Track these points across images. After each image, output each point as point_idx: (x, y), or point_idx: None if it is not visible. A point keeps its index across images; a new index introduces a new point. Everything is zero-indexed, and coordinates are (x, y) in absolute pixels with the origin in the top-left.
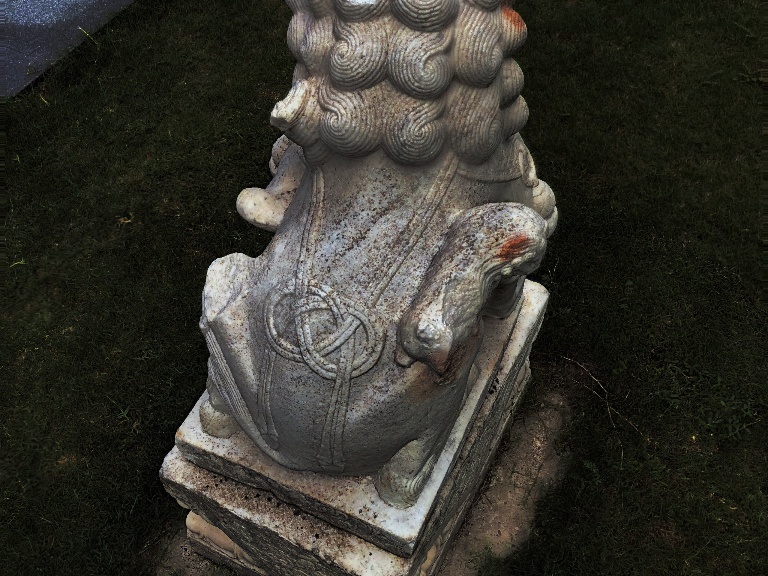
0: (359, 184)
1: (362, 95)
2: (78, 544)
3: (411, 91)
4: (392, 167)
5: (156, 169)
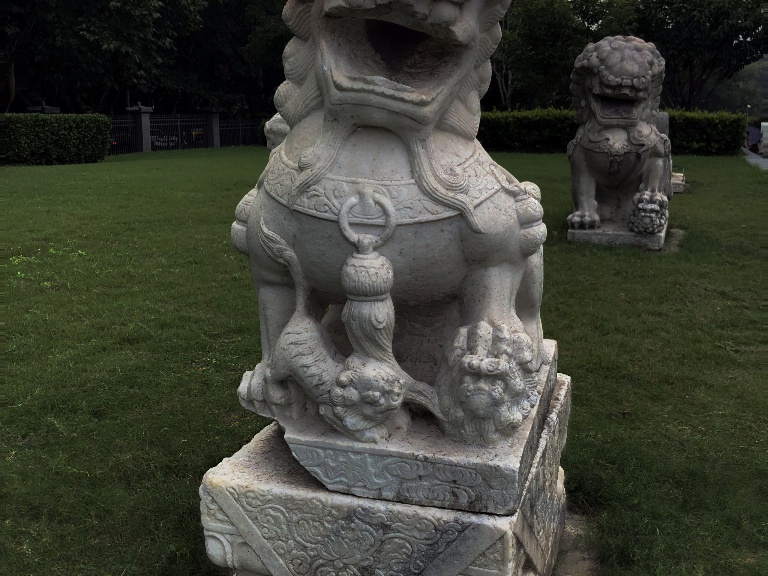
0: None
1: None
2: None
3: None
4: None
5: None
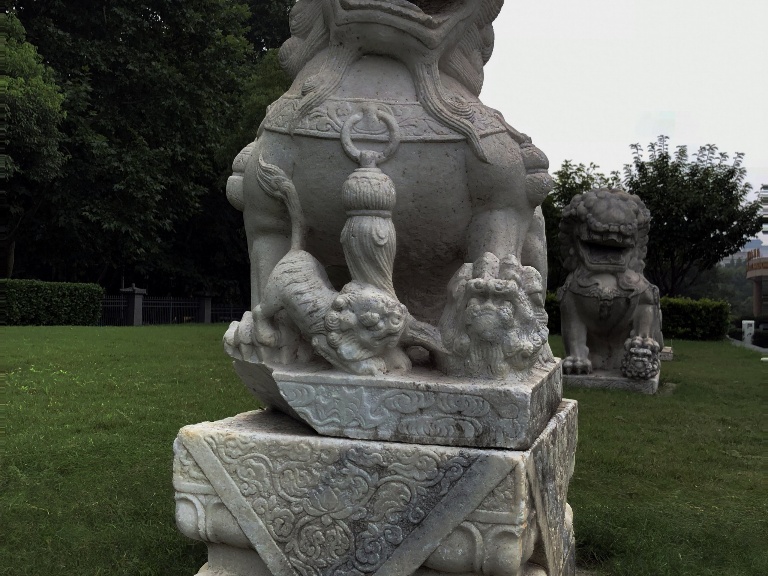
0: None
1: None
2: (688, 569)
3: None
4: None
5: None
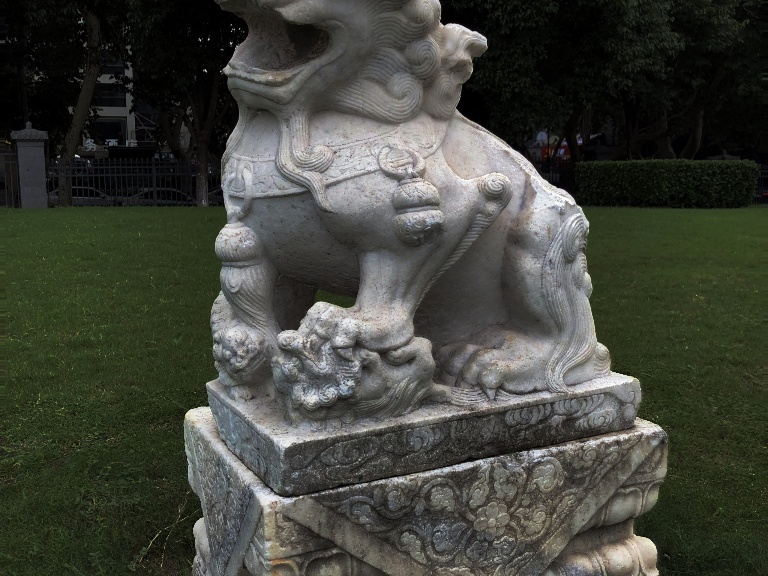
0: None
1: None
2: None
3: None
4: None
5: None
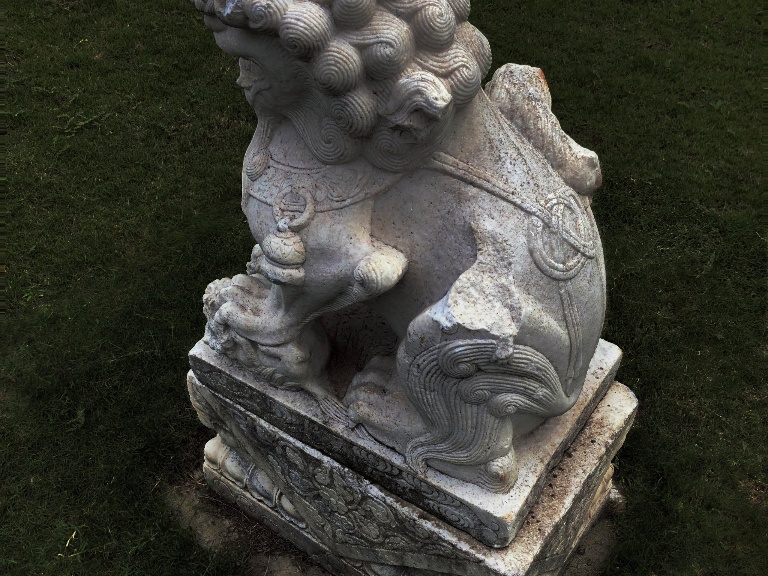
0: (481, 121)
1: (457, 41)
2: None
3: (466, 15)
4: (479, 91)
5: None
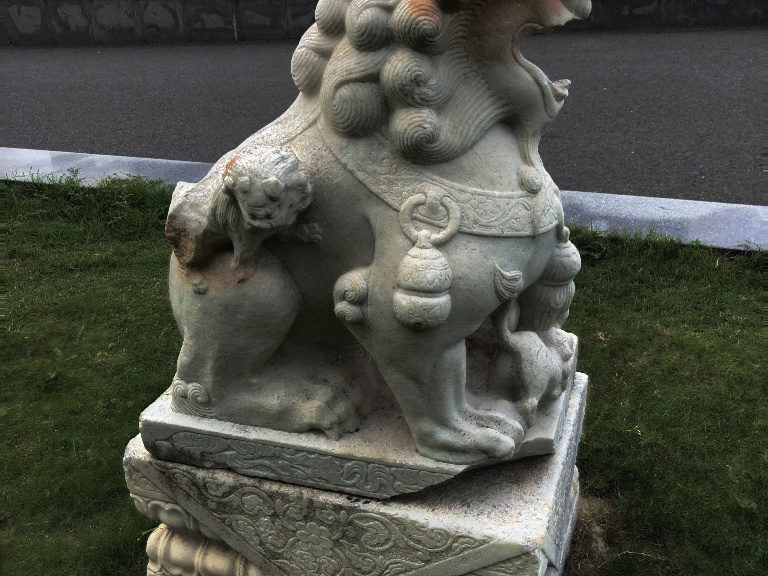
0: None
1: None
2: None
3: None
4: None
5: (682, 338)
